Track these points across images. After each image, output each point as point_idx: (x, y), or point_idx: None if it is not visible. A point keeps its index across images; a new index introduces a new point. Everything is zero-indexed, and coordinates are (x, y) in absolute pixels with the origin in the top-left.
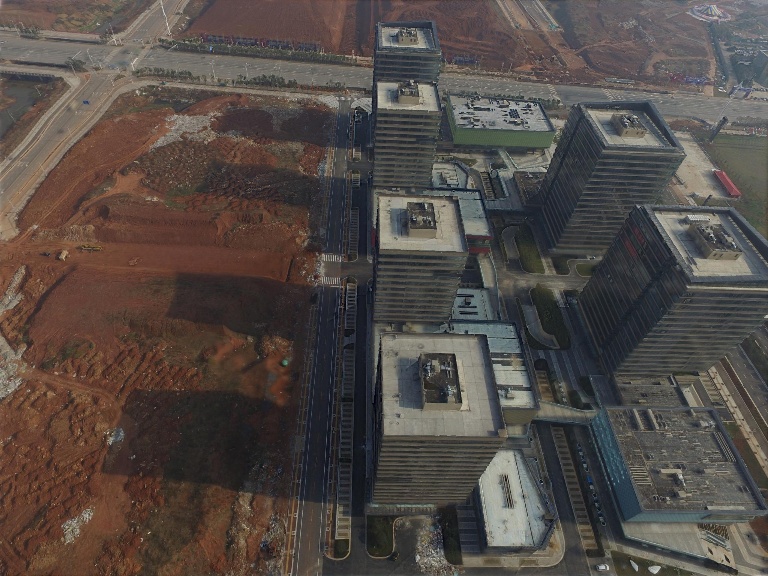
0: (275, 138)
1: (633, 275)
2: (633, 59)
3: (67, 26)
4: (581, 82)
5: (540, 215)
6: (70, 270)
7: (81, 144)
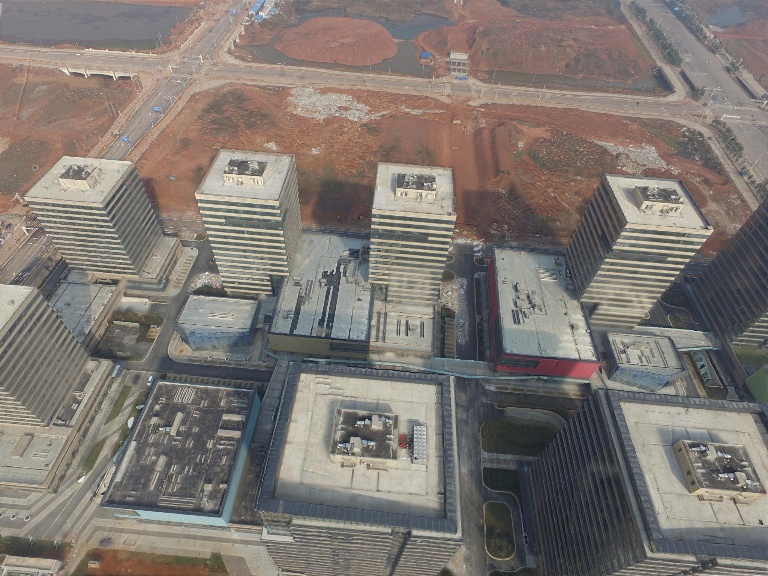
0: None
1: None
2: None
3: None
4: None
5: None
6: None
7: (579, 110)
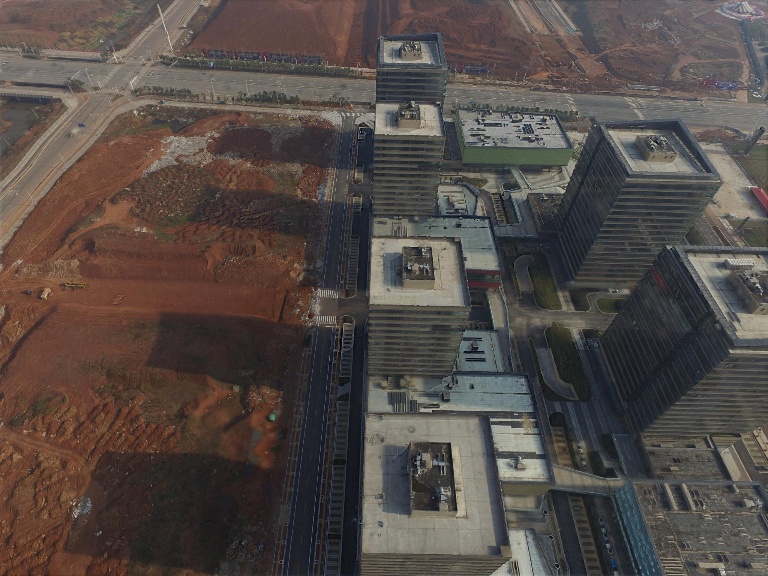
0: (274, 159)
1: (663, 326)
2: (658, 63)
3: (70, 44)
4: (601, 90)
5: (556, 242)
6: (50, 311)
7: (73, 170)
